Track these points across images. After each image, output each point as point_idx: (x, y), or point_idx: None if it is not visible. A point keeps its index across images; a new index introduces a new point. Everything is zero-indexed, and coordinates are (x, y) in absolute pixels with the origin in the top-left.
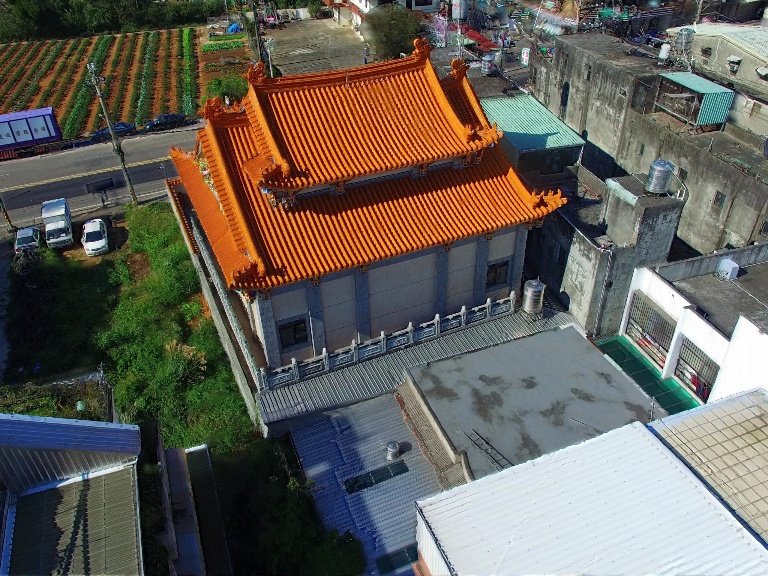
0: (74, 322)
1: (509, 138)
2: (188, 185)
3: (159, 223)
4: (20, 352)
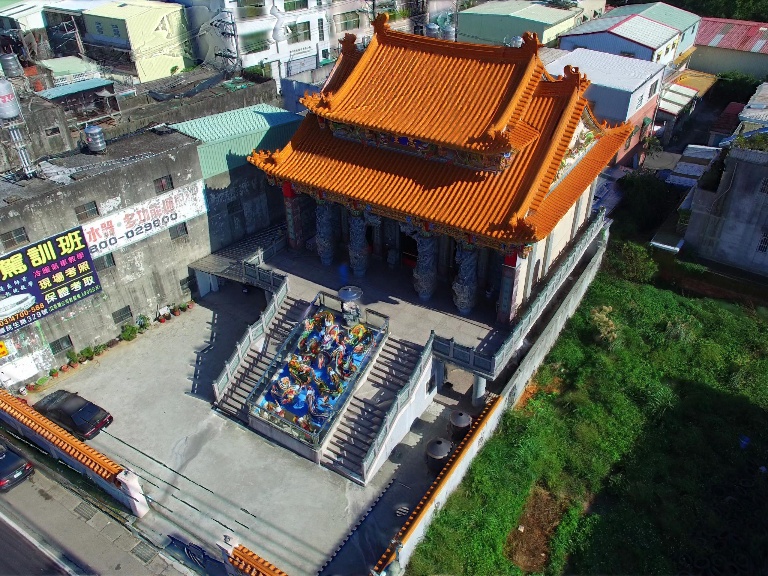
0: (681, 476)
1: (285, 122)
2: (561, 212)
3: (443, 574)
4: (761, 479)
